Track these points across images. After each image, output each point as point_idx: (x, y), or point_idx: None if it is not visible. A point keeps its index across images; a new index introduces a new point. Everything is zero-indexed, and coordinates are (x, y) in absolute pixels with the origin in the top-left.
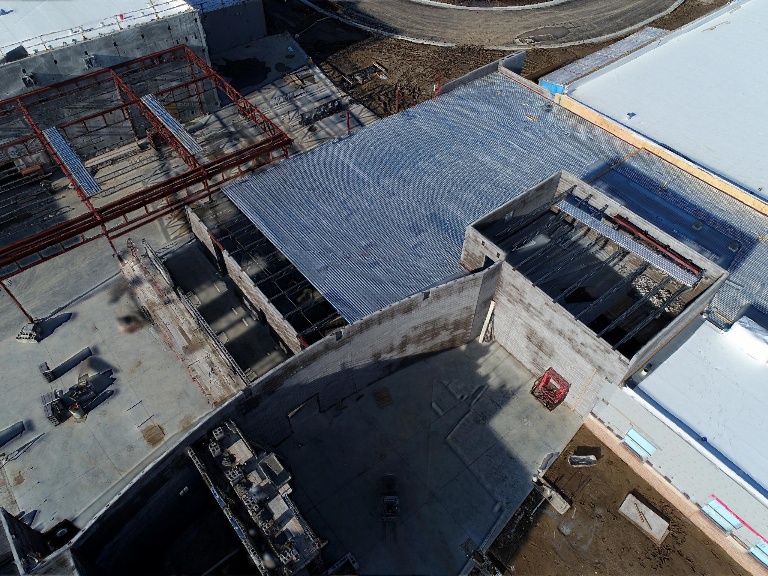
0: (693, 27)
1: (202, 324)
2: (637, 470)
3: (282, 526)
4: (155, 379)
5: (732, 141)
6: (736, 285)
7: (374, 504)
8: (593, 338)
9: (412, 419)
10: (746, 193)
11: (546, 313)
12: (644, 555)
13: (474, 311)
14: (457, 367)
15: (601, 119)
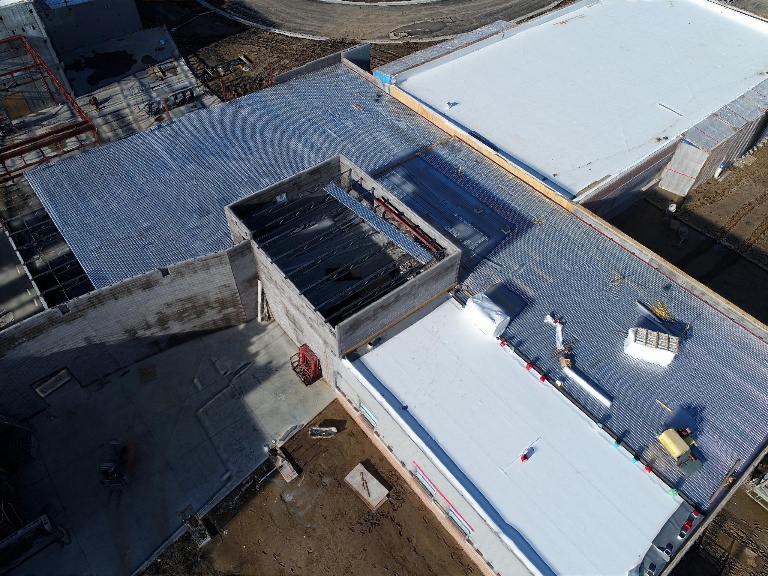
0: (545, 20)
1: None
2: (374, 441)
3: None
4: None
5: (544, 129)
6: (495, 265)
7: None
8: (312, 312)
9: (170, 393)
10: (534, 178)
11: (285, 289)
12: (356, 520)
13: (236, 289)
14: (230, 345)
15: (421, 108)
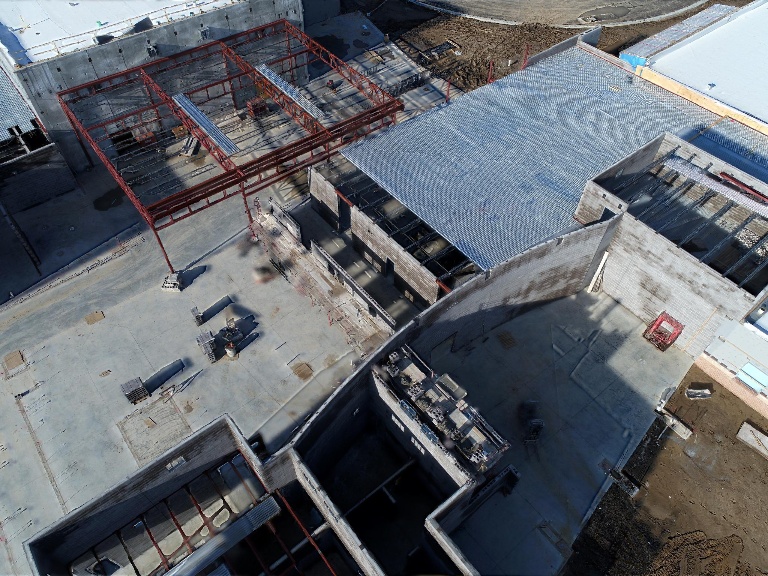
0: (758, 4)
1: (339, 272)
2: (749, 402)
3: (465, 434)
4: (295, 323)
5: None
6: None
7: (514, 430)
8: (718, 278)
9: (536, 358)
10: None
11: (667, 258)
12: (764, 474)
13: (591, 260)
14: (571, 314)
15: (684, 89)
